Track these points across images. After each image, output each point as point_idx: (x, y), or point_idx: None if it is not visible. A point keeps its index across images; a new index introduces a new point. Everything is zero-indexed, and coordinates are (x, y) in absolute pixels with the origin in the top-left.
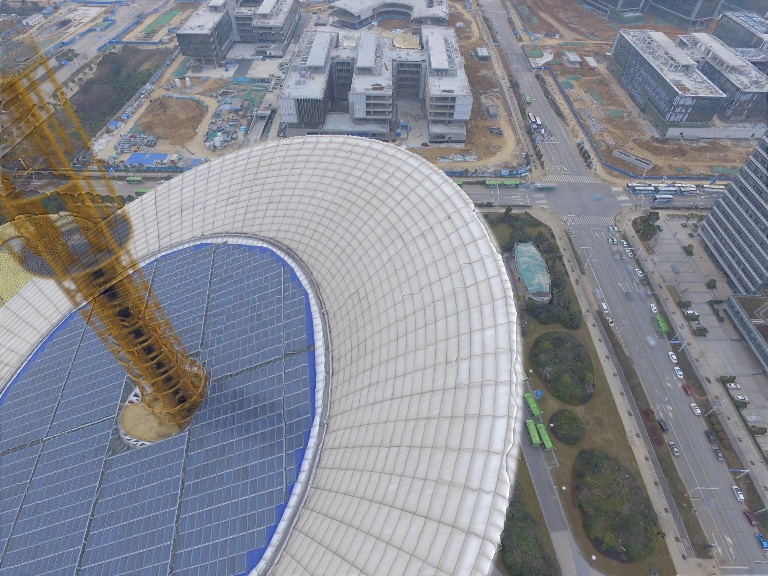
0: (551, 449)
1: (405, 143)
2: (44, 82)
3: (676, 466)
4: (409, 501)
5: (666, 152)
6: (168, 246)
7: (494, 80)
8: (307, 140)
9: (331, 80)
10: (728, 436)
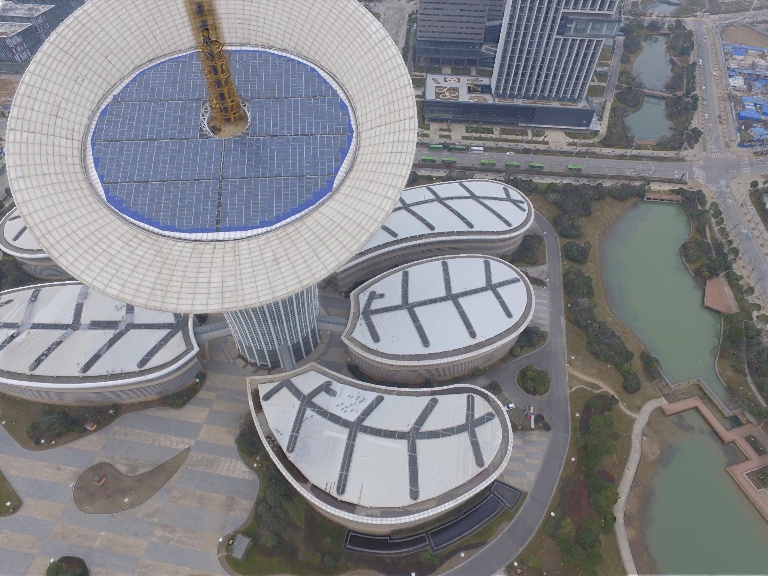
0: None
1: None
2: None
3: None
4: (311, 2)
5: None
6: (83, 135)
7: None
8: (76, 15)
9: None
10: None
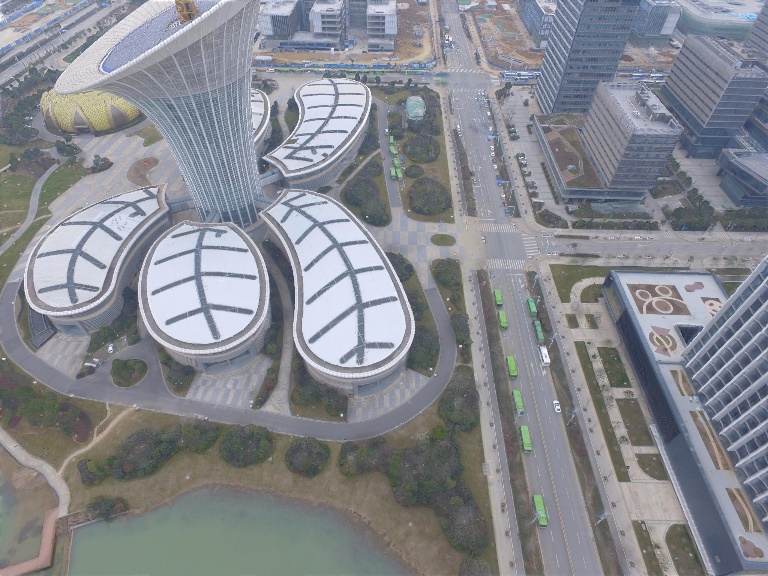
0: (403, 180)
1: (351, 51)
2: (89, 17)
3: (473, 187)
4: None
5: (537, 56)
6: None
7: (427, 17)
8: None
9: (300, 10)
10: (509, 177)
